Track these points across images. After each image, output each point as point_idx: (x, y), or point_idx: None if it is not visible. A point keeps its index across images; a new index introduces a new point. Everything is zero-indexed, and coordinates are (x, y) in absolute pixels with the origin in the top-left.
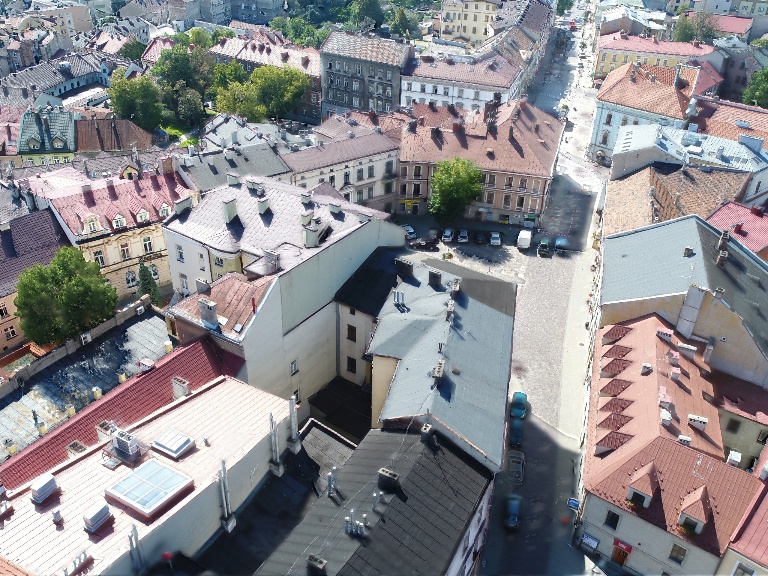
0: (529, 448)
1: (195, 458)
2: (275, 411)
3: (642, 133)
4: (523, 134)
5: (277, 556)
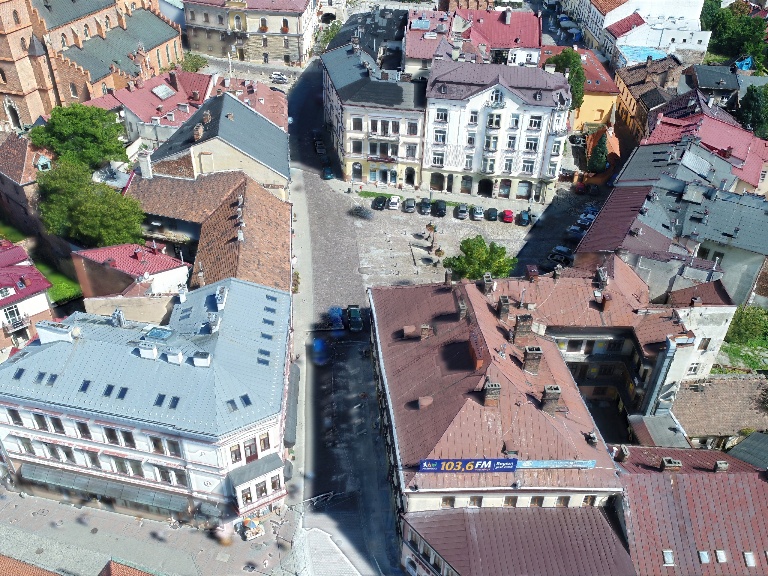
0: (317, 160)
1: (420, 36)
2: (413, 53)
3: (244, 339)
4: (434, 294)
5: (379, 42)
